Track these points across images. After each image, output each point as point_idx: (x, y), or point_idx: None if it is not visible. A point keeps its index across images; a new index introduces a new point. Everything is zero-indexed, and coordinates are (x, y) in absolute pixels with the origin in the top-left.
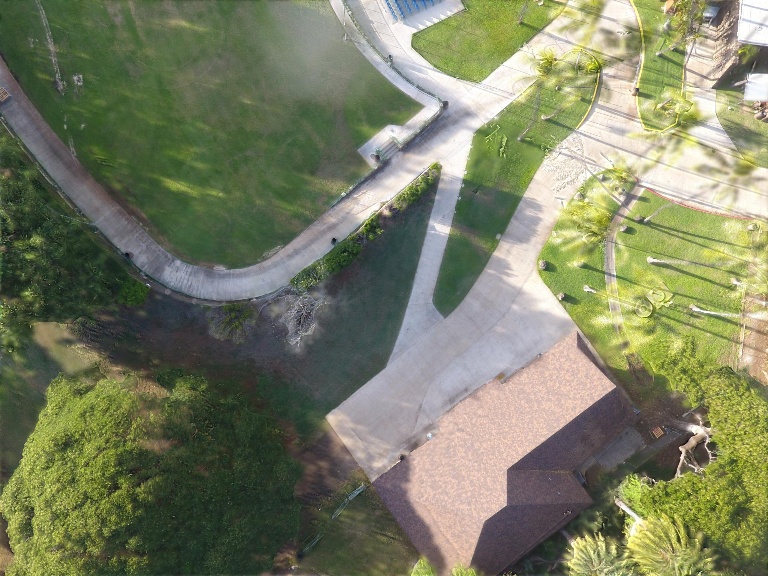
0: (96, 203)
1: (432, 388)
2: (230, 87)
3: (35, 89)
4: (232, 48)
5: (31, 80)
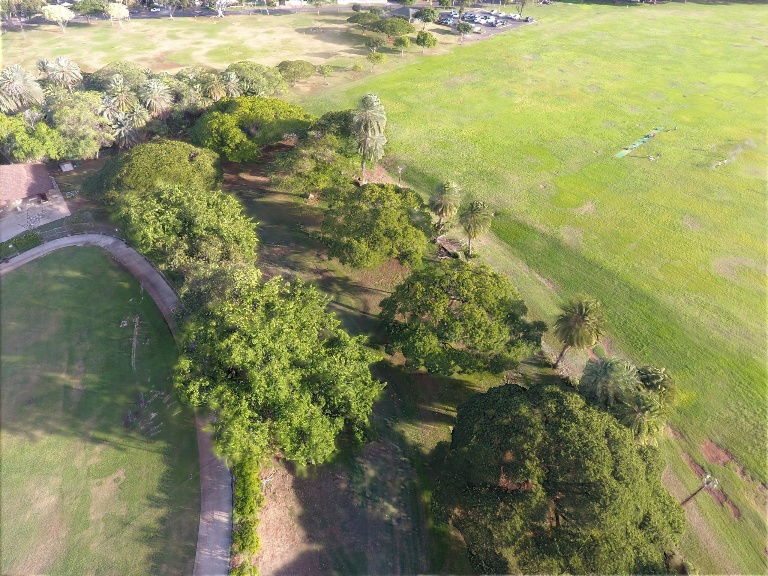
0: (138, 266)
1: (5, 225)
2: (20, 331)
3: (154, 316)
4: (3, 355)
5: (155, 320)
